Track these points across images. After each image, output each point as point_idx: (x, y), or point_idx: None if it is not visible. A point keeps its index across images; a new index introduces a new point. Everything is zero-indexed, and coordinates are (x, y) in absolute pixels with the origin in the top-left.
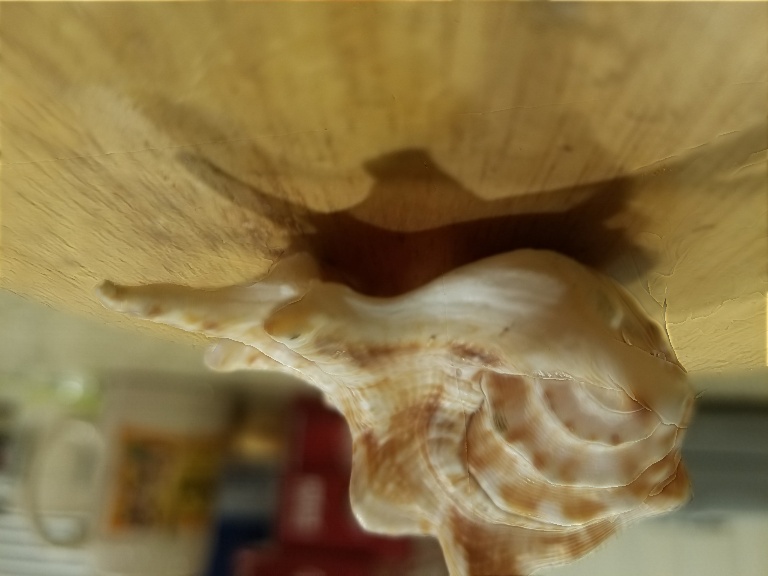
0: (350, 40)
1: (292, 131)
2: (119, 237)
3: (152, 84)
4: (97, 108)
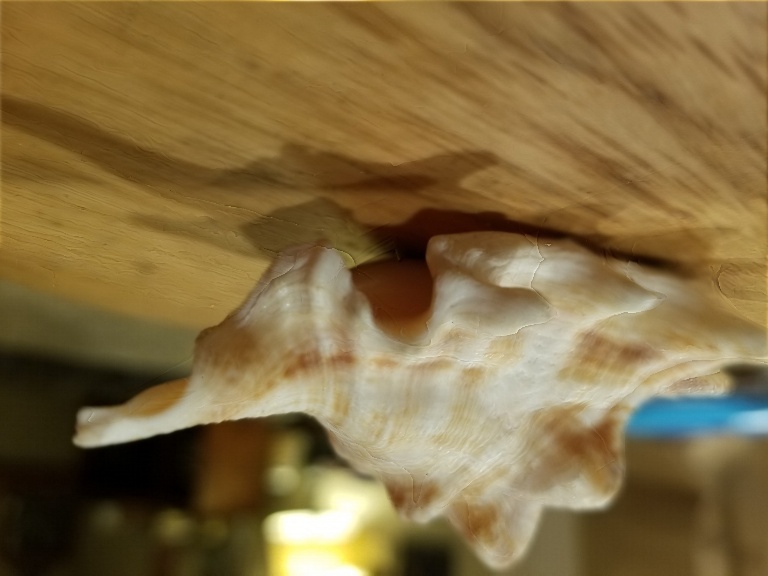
0: None
1: None
2: None
3: None
4: None
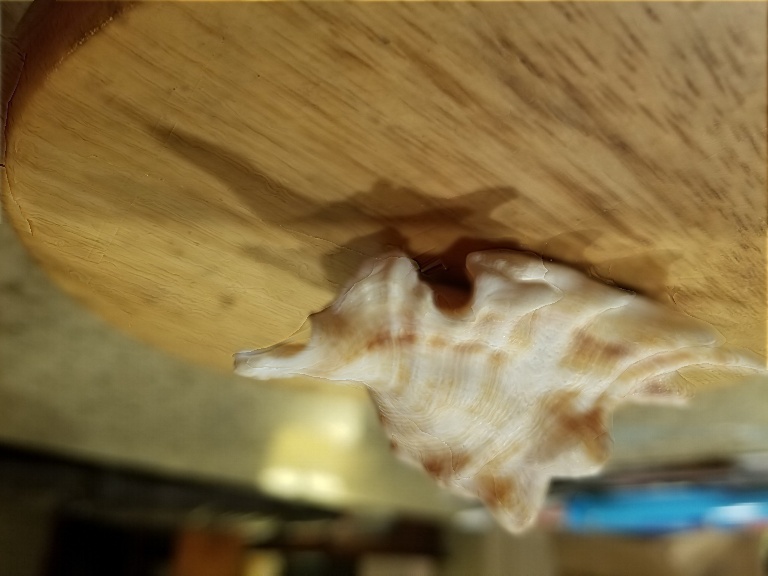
0: None
1: None
2: None
3: (744, 341)
4: (767, 332)
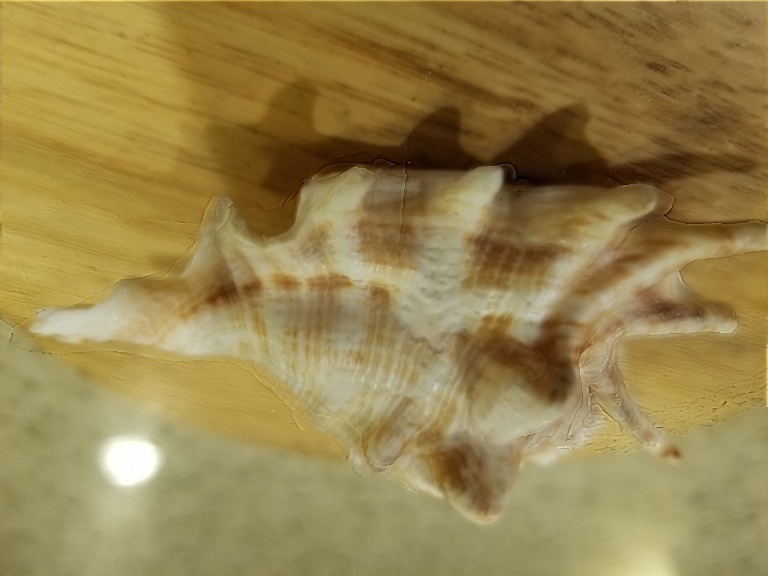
0: (753, 295)
1: (735, 261)
2: (764, 94)
3: None
4: None
